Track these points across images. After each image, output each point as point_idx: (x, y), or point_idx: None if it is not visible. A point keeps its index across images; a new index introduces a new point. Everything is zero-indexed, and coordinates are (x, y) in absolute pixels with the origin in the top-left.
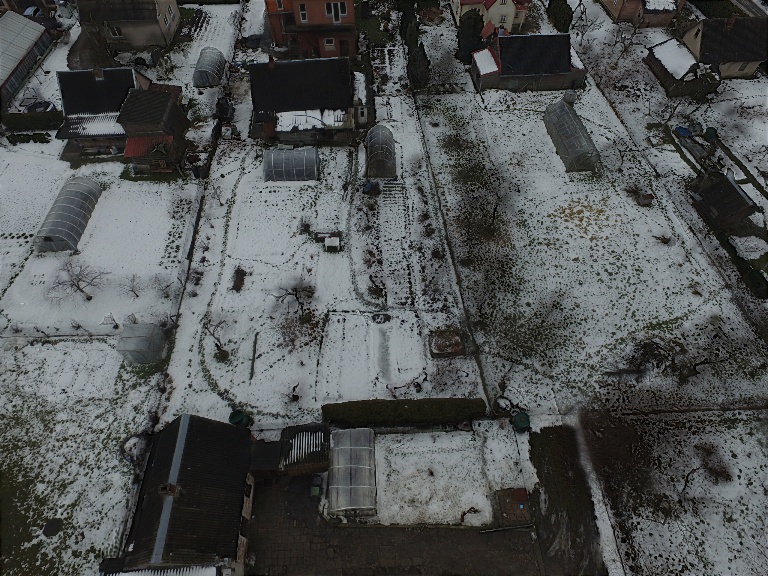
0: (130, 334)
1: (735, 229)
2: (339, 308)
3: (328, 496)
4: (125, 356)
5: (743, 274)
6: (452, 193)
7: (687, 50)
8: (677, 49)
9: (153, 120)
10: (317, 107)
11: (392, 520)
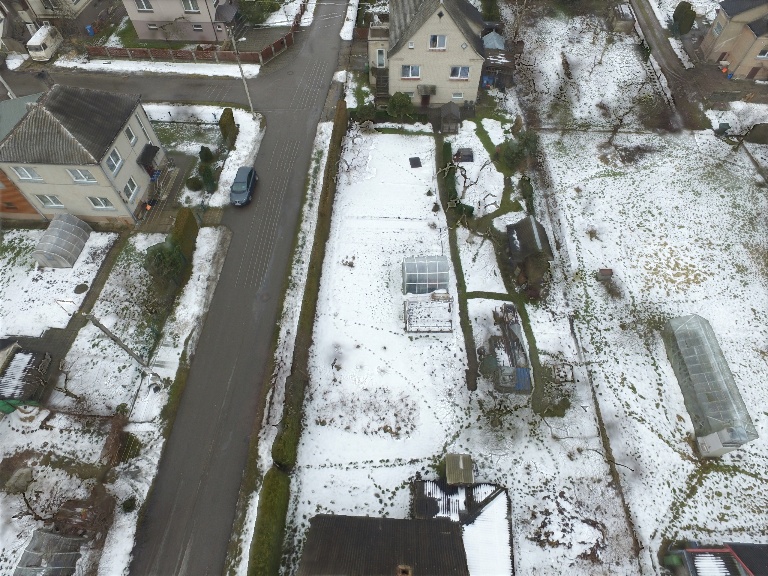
0: None
1: None
2: None
3: None
4: None
5: None
6: None
7: None
8: None
9: None
10: None
11: None
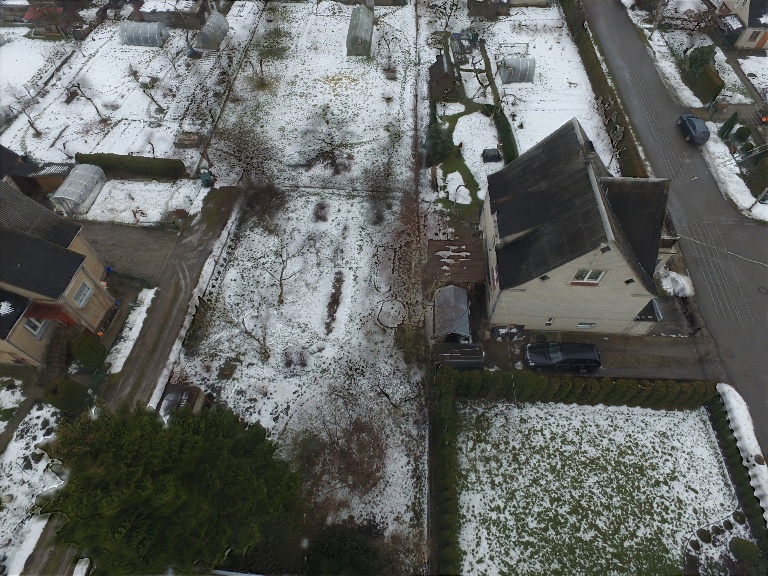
0: None
1: None
2: (130, 118)
3: None
4: None
5: None
6: (253, 62)
7: None
8: None
9: None
10: None
11: (95, 218)
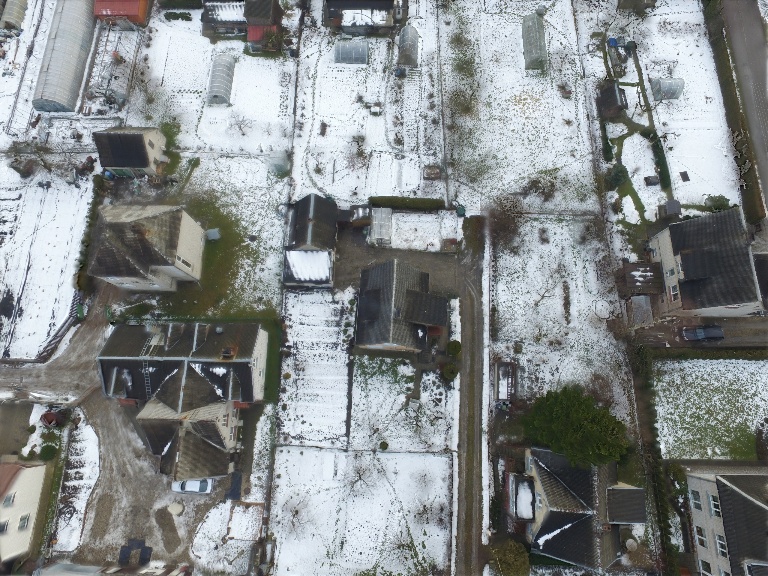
0: (274, 156)
1: (613, 118)
2: (378, 149)
3: (370, 235)
4: (271, 167)
5: (603, 146)
6: (450, 80)
7: None
8: None
9: (265, 15)
10: (369, 8)
11: (397, 246)
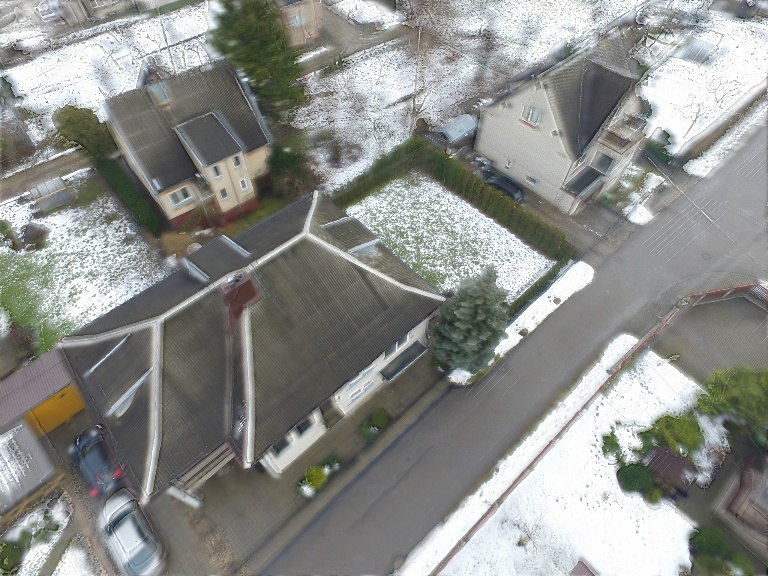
0: None
1: None
2: None
3: None
4: None
5: None
6: None
7: None
8: None
9: None
10: None
11: (332, 9)
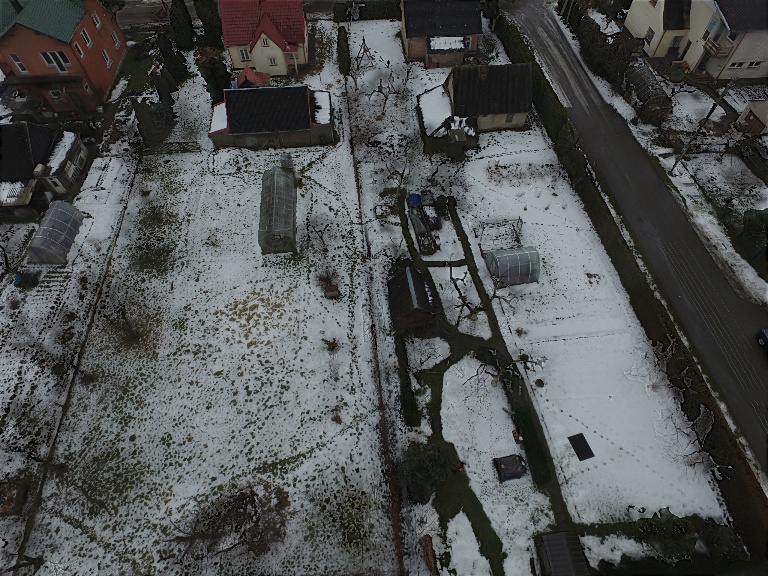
0: None
1: (422, 328)
2: None
3: None
4: None
5: (402, 391)
6: (119, 284)
7: (448, 100)
8: (440, 98)
9: None
10: None
11: None
